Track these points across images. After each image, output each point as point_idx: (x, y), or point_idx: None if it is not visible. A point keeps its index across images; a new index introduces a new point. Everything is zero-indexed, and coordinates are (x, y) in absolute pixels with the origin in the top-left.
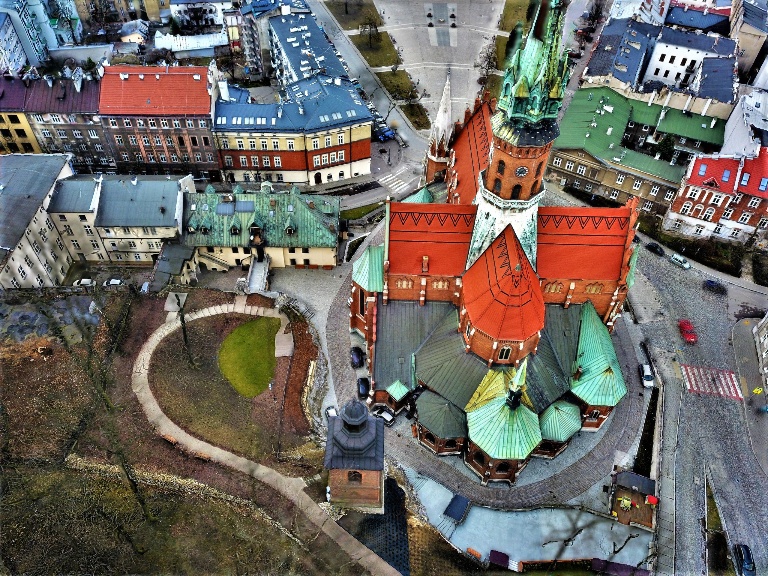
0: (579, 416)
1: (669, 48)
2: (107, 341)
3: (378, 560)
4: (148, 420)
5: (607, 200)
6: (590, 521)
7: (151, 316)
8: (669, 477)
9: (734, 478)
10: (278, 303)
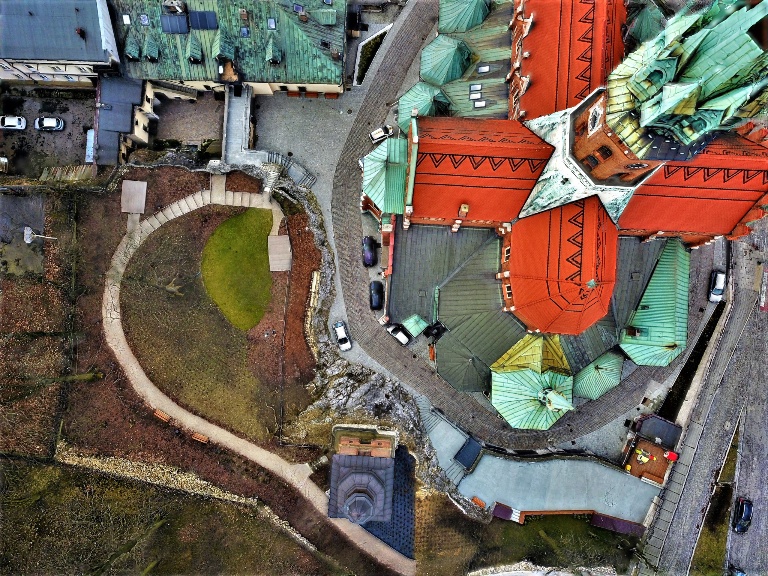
0: (620, 369)
1: None
2: (61, 271)
3: (385, 548)
4: (134, 388)
5: None
6: (601, 473)
7: (107, 225)
8: (699, 422)
9: None
10: (267, 180)
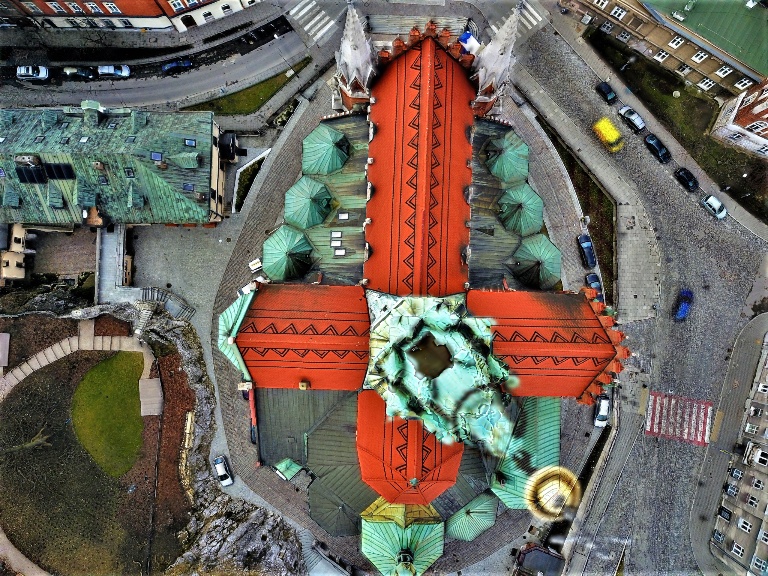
0: (495, 510)
1: None
2: None
3: None
4: None
5: (647, 61)
6: None
7: None
8: (583, 553)
9: (654, 552)
10: (139, 321)
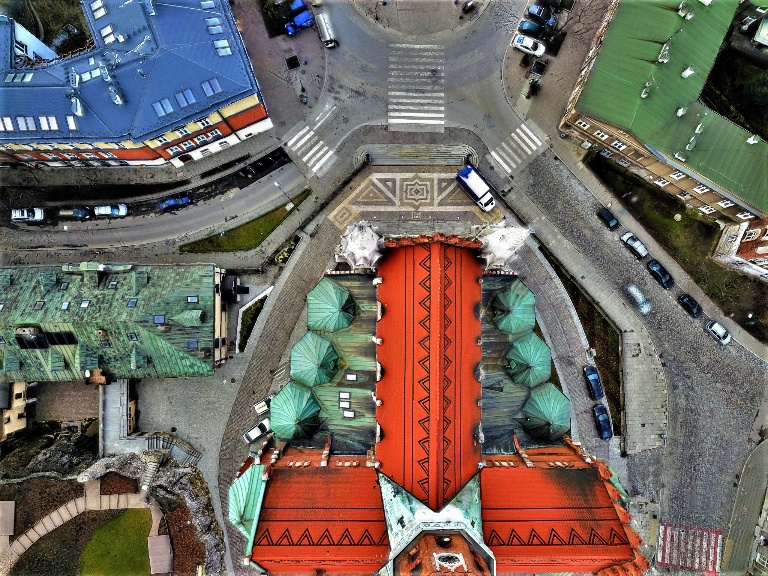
0: None
1: None
2: None
3: None
4: None
5: (648, 184)
6: None
7: None
8: None
9: None
10: (146, 476)
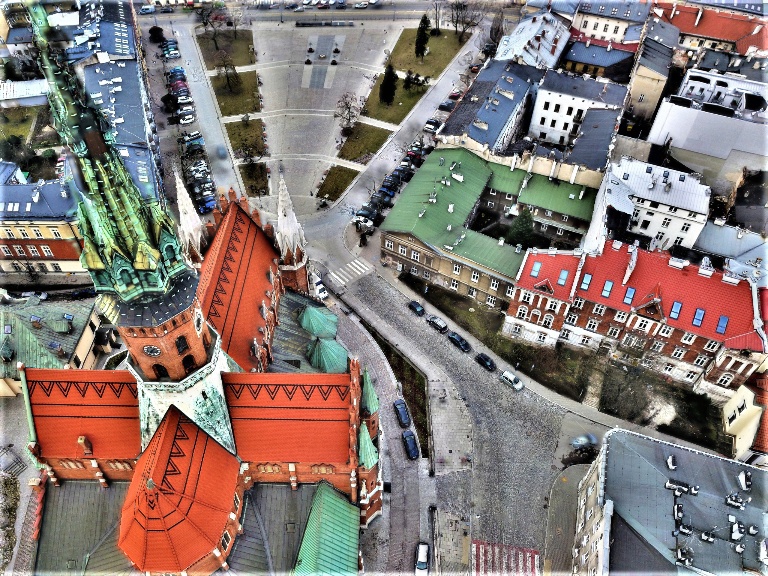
0: None
1: (552, 96)
2: None
3: None
4: None
5: (448, 291)
6: None
7: None
8: None
9: None
10: None
